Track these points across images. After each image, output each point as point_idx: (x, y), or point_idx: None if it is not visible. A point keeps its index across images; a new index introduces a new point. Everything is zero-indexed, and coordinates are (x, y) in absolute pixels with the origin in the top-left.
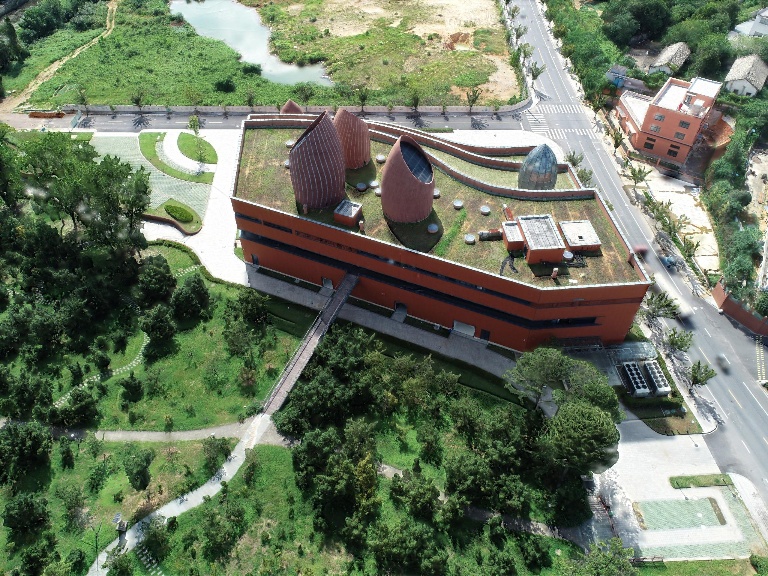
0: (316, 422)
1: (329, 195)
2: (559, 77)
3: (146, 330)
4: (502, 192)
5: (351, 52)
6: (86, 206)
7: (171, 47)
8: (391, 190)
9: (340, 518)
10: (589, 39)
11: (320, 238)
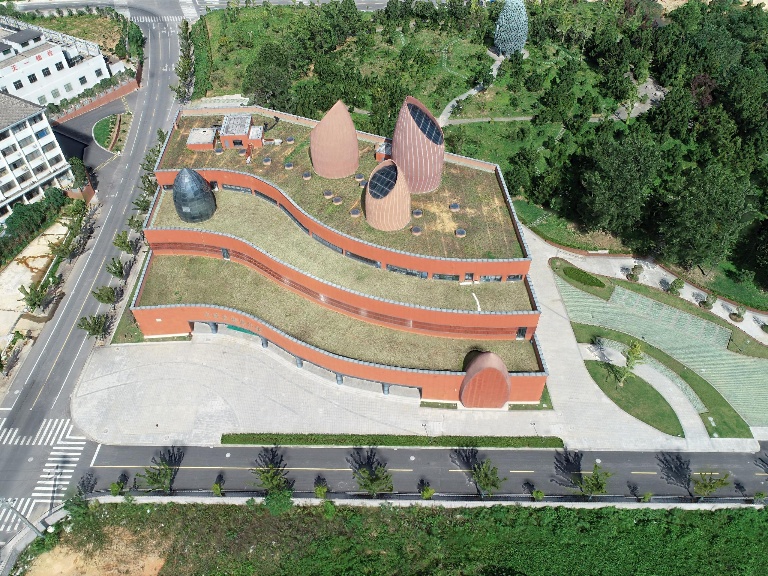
0: None
1: None
2: None
3: None
4: None
5: None
6: None
7: None
8: None
9: None
10: None
11: None
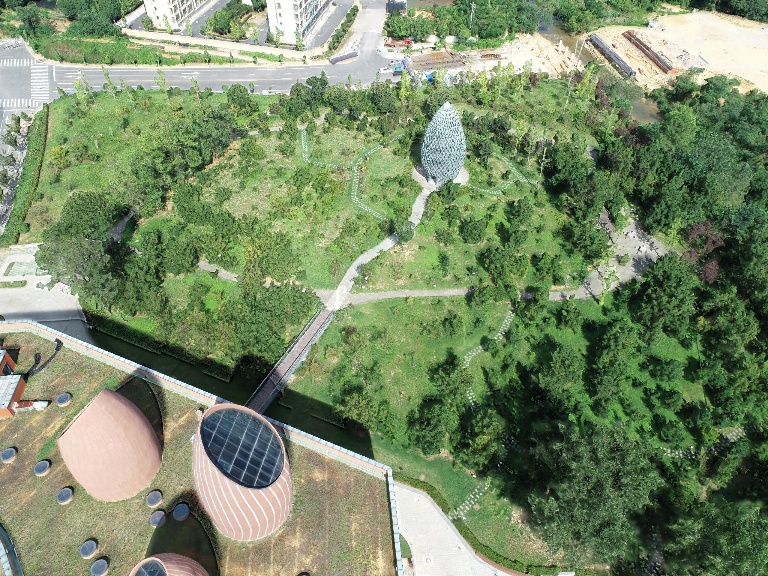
0: None
1: None
2: None
3: None
4: None
5: None
6: None
7: None
8: None
9: None
10: None
11: None
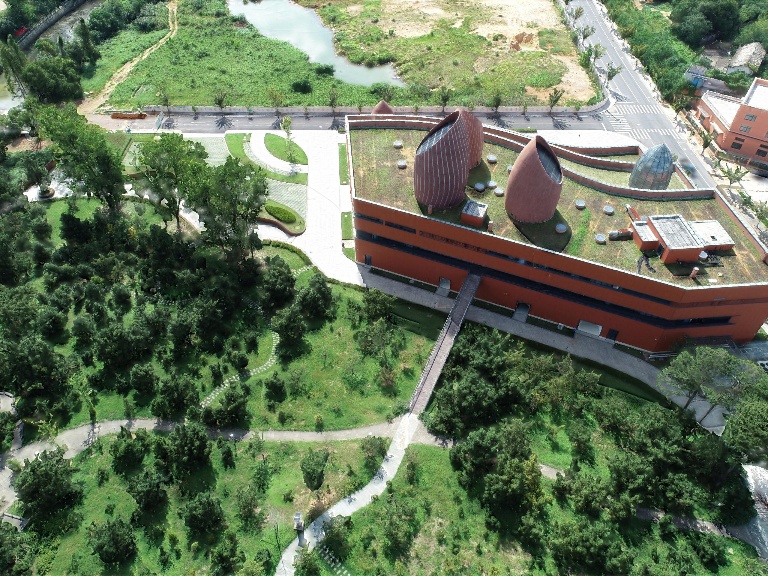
0: (469, 422)
1: (454, 195)
2: (631, 77)
3: (280, 330)
4: (621, 192)
5: (419, 53)
6: (208, 207)
7: (239, 48)
8: (522, 190)
9: (510, 517)
10: (661, 39)
11: (446, 238)
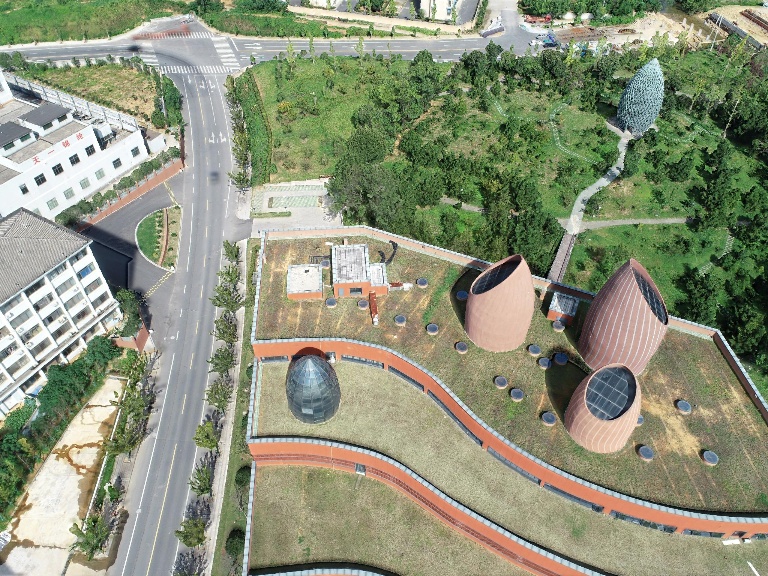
0: None
1: None
2: None
3: None
4: None
5: None
6: None
7: None
8: None
9: None
10: None
11: None
